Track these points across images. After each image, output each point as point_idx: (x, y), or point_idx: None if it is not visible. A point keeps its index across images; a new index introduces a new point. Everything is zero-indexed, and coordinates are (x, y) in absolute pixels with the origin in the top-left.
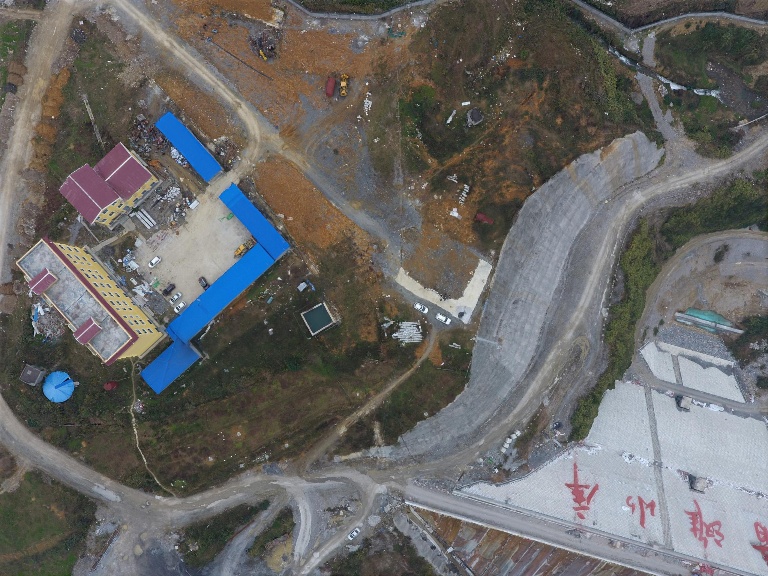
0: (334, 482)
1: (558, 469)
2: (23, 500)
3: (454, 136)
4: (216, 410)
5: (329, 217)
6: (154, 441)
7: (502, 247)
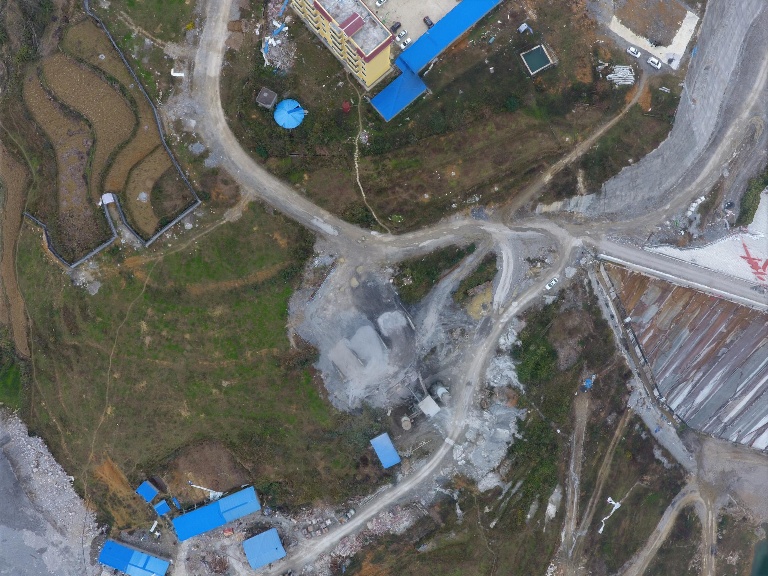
0: (534, 233)
1: (730, 246)
2: (245, 229)
3: None
4: (434, 148)
5: None
6: (375, 175)
7: (708, 0)
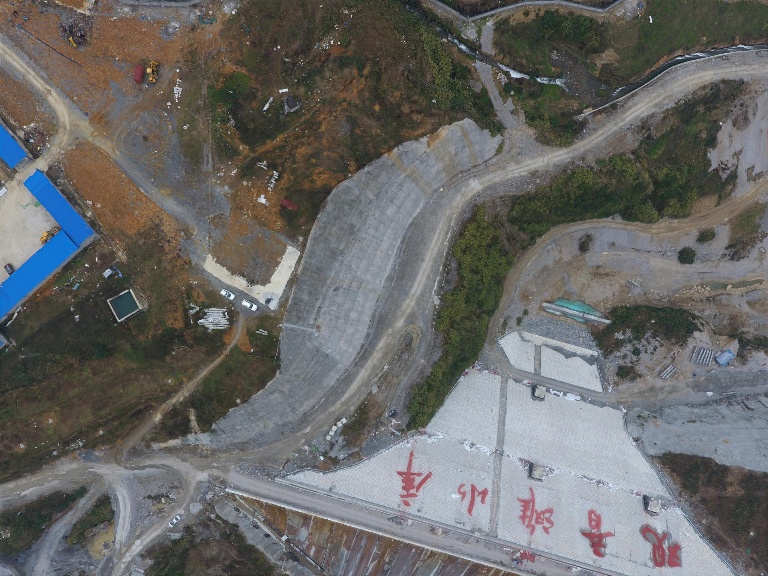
0: (154, 469)
1: (393, 457)
2: None
3: (268, 123)
4: (26, 397)
5: (137, 204)
6: None
7: (310, 233)
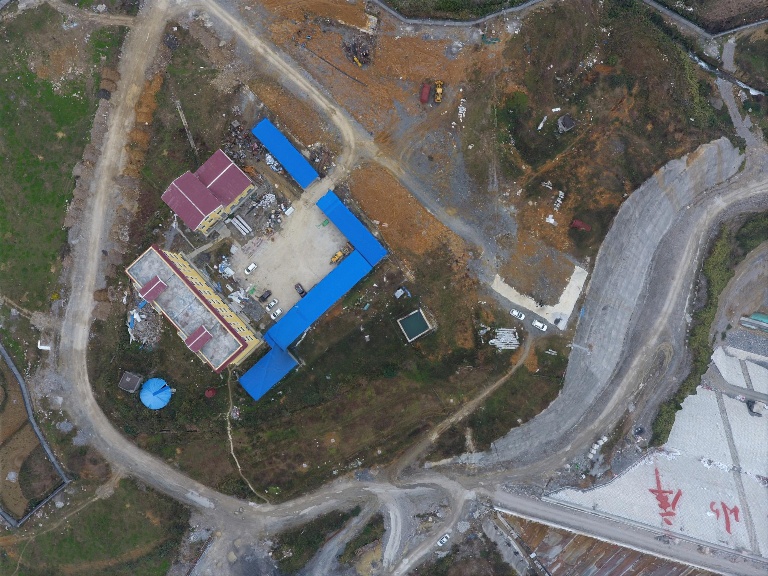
0: (424, 488)
1: (640, 475)
2: (117, 507)
3: (547, 142)
4: (311, 417)
5: (424, 223)
6: (249, 448)
7: (598, 254)
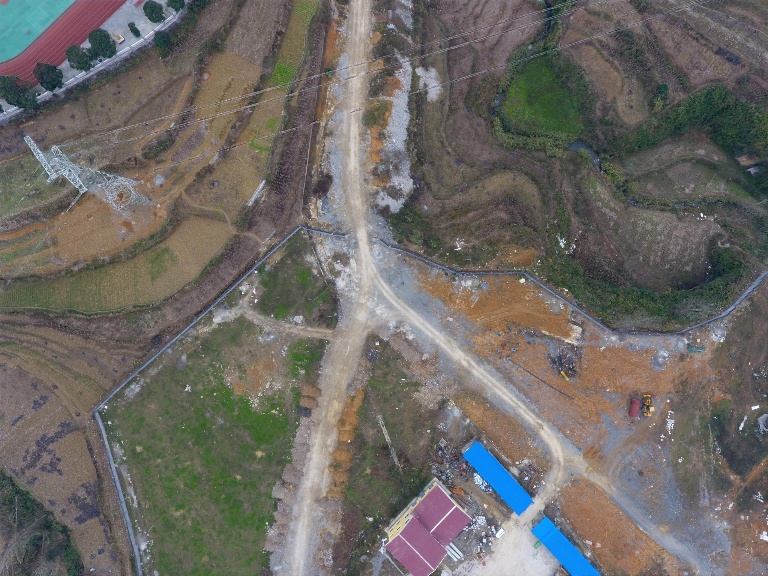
0: None
1: None
2: None
3: (752, 448)
4: None
5: (637, 543)
6: None
7: None
